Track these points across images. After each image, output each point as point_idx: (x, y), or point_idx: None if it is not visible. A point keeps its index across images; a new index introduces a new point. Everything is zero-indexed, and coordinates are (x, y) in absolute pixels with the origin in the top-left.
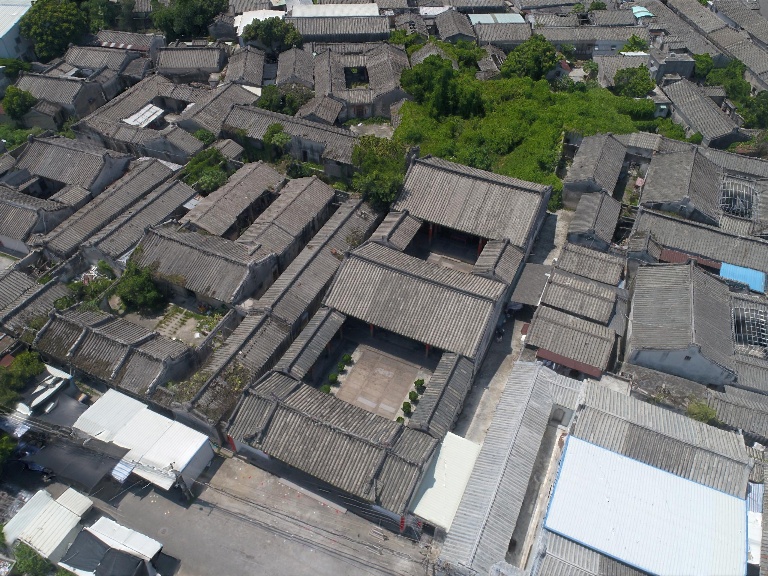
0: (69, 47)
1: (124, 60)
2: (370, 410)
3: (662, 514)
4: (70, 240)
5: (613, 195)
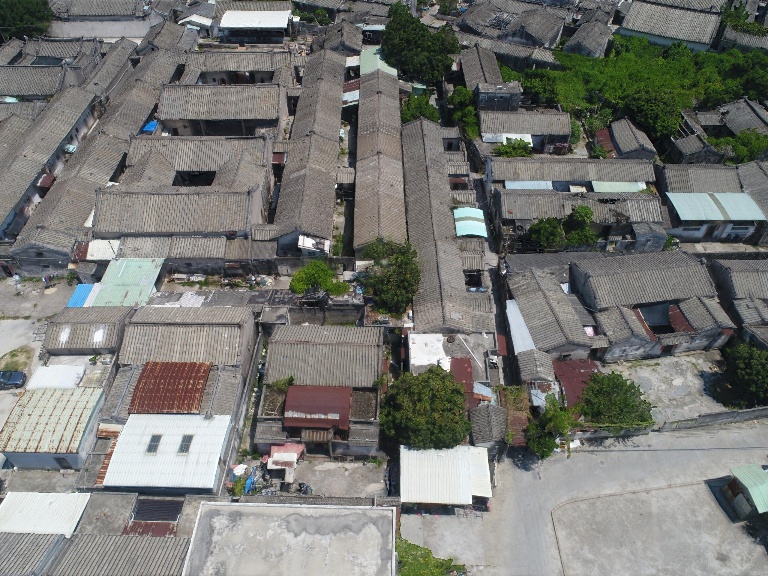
0: None
1: None
2: None
3: None
4: None
5: None
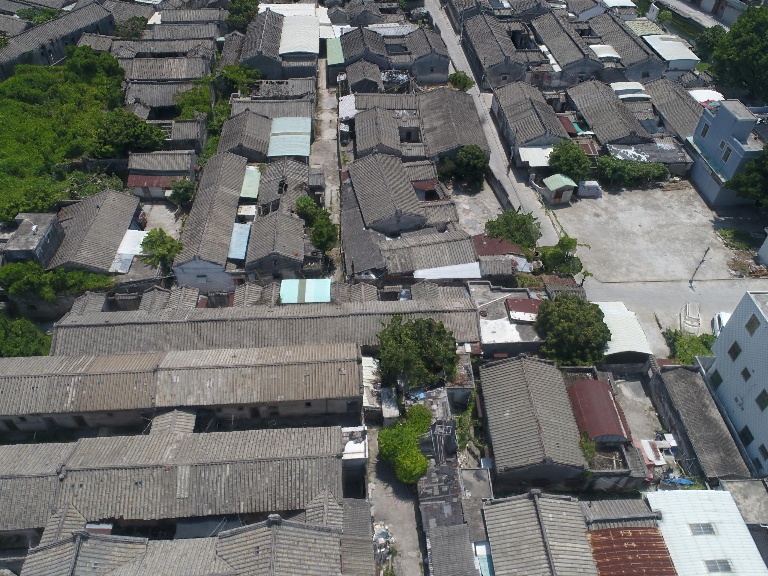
0: None
1: None
2: None
3: None
4: None
5: None
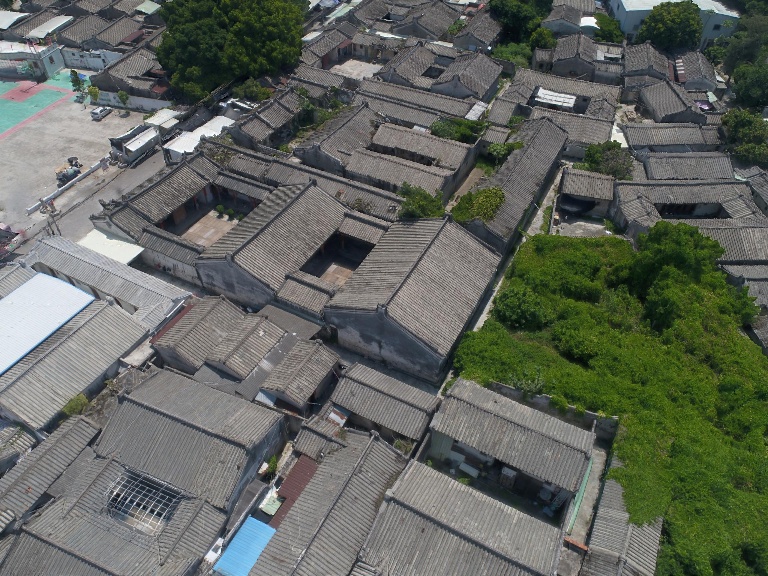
0: (645, 43)
1: (640, 70)
2: (202, 235)
3: (2, 330)
4: (371, 88)
5: (497, 486)
